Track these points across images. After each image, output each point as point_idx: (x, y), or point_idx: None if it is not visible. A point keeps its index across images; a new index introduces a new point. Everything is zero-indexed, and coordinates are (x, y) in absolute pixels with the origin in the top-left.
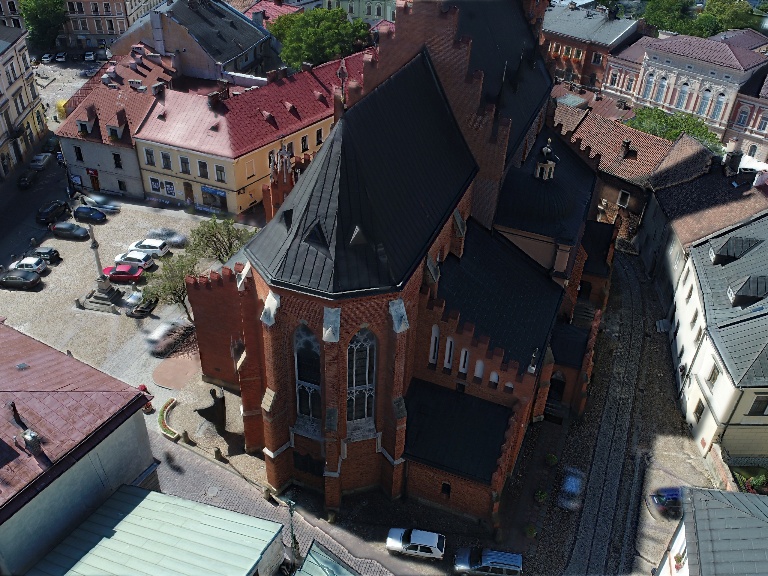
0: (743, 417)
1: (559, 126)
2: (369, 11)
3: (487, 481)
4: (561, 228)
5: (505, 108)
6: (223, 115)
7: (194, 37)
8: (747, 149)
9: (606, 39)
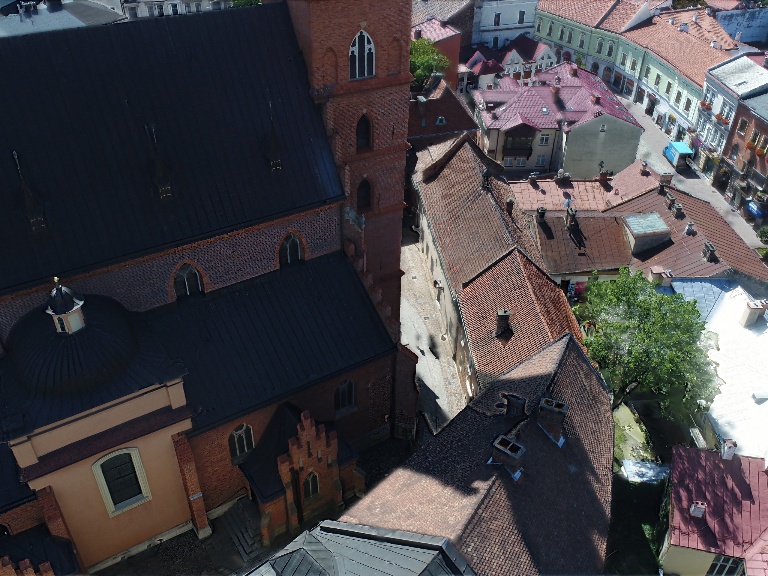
0: None
1: (355, 258)
2: (600, 48)
3: None
4: (26, 408)
5: (93, 214)
6: None
7: None
8: None
9: None
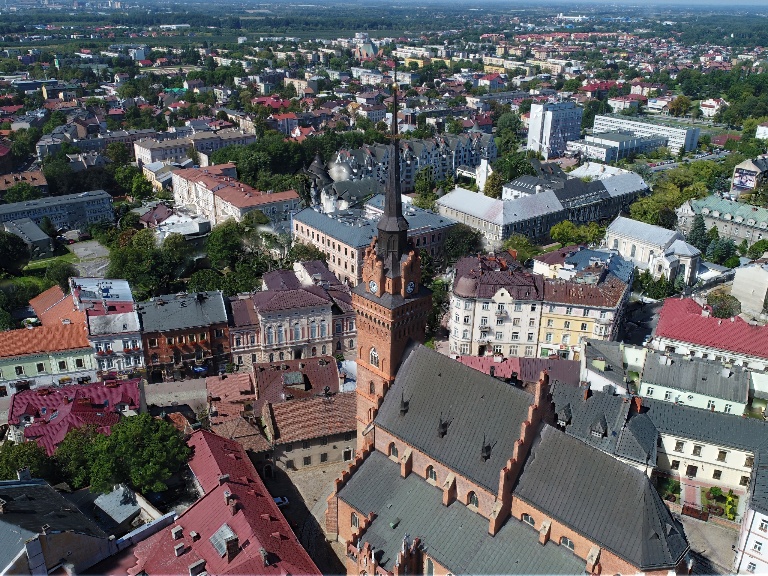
0: None
1: None
2: None
3: (689, 575)
4: None
5: None
6: (280, 561)
7: (81, 533)
8: (348, 344)
9: (219, 318)
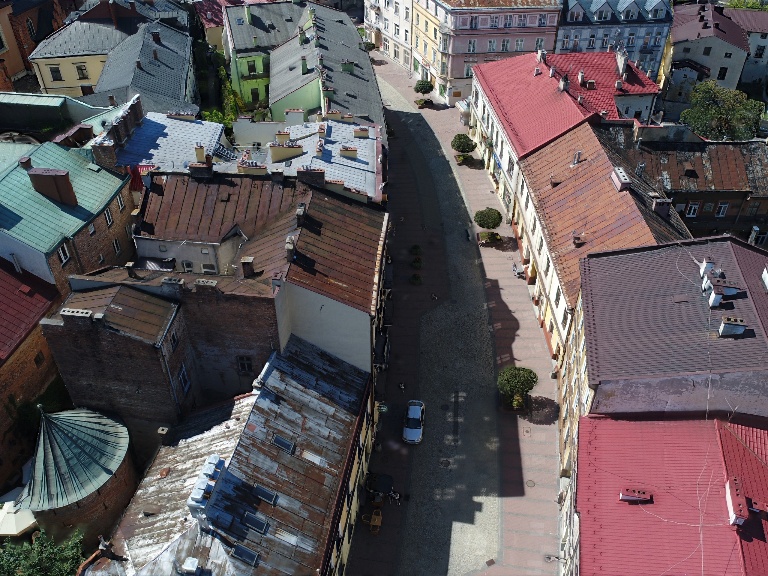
0: (52, 83)
1: None
2: None
3: None
4: None
5: None
6: None
7: None
8: None
9: None
